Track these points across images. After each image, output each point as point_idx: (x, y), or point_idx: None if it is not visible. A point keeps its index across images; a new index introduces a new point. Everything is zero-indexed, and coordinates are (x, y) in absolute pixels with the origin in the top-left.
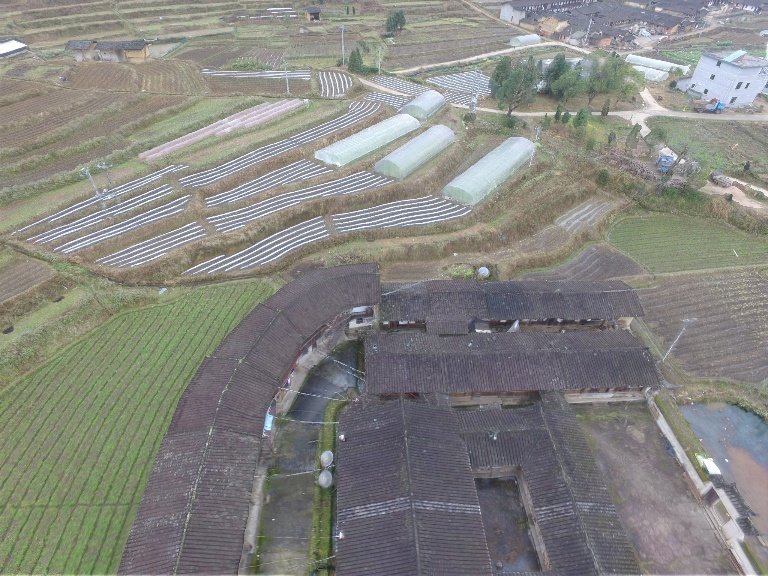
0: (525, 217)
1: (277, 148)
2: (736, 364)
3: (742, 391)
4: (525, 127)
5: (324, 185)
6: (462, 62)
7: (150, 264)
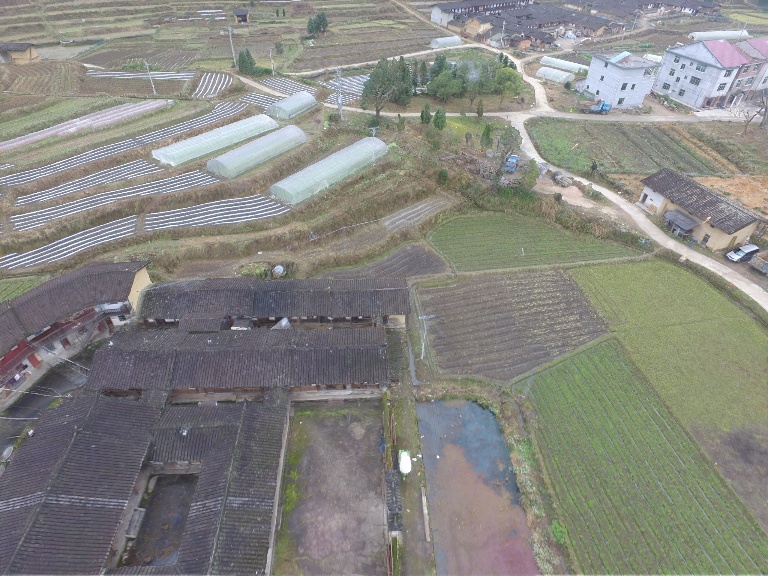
0: (343, 216)
1: (117, 148)
2: (495, 362)
3: (486, 388)
4: (389, 127)
5: (149, 184)
6: (371, 64)
7: None
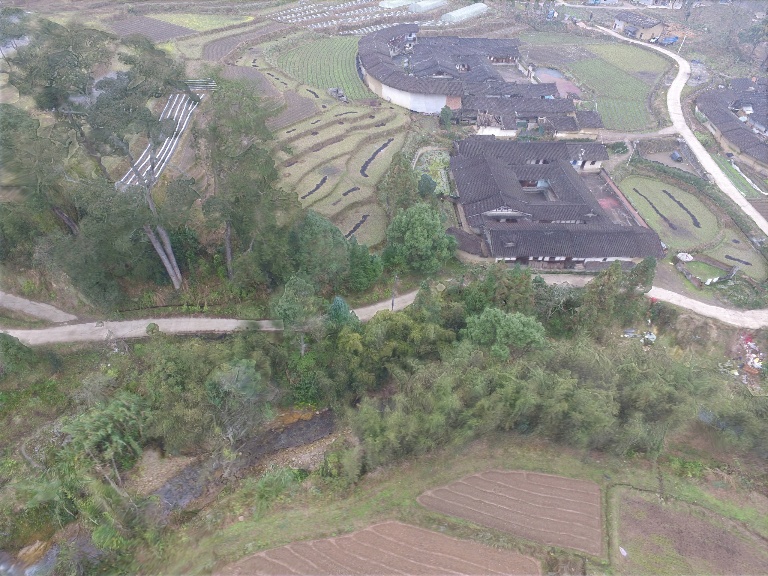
0: (478, 26)
1: None
2: None
3: None
4: (483, 2)
5: None
6: None
7: (325, 27)
